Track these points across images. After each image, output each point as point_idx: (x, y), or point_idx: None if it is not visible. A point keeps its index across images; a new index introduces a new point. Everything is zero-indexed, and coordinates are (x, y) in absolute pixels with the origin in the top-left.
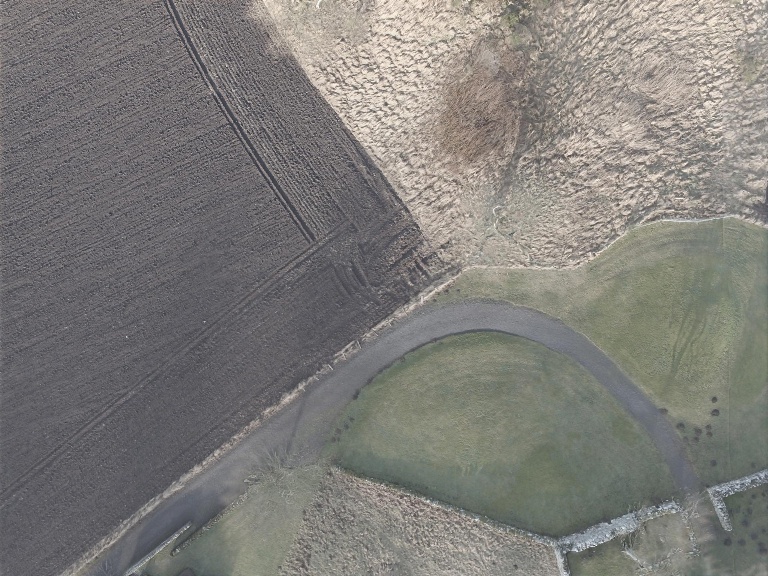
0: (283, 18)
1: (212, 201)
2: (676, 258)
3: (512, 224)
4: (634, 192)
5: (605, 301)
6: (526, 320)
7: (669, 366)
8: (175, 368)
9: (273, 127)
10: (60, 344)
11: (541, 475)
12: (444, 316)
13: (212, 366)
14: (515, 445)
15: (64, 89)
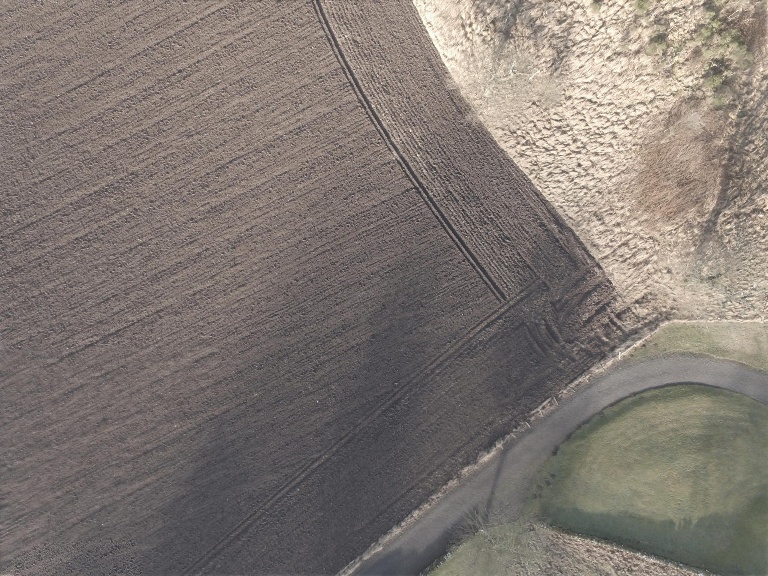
0: (469, 83)
1: (399, 264)
2: None
3: (713, 279)
4: None
5: None
6: (728, 372)
7: None
8: (368, 430)
9: (460, 190)
10: (250, 411)
11: (761, 527)
12: (642, 370)
13: (406, 427)
14: (730, 498)
15: (243, 159)
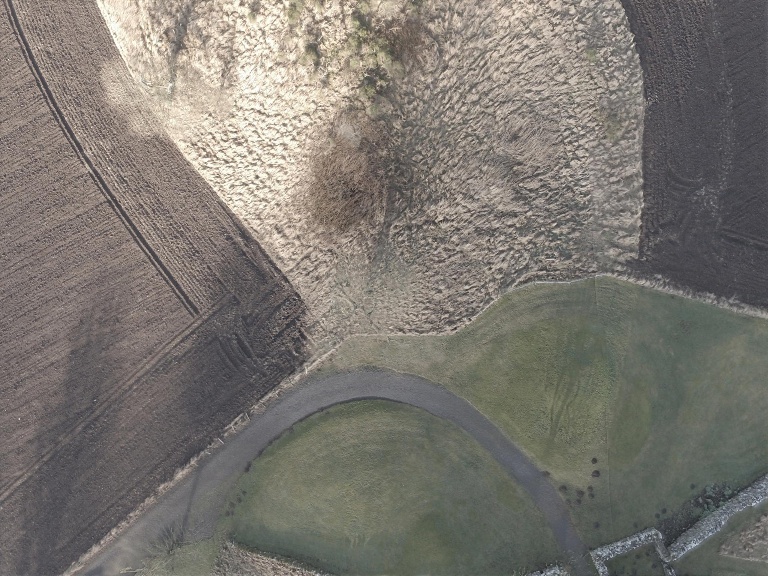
0: None
1: (95, 279)
2: (549, 320)
3: (388, 292)
4: (505, 255)
5: (483, 365)
6: (409, 386)
7: (548, 429)
8: (69, 448)
9: (150, 203)
10: None
11: (425, 545)
12: (329, 385)
13: (105, 444)
14: (400, 515)
15: None
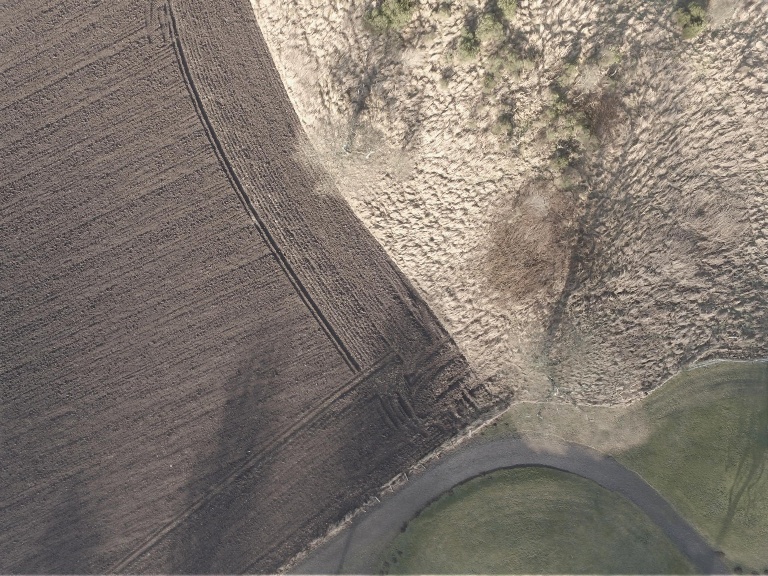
0: (326, 151)
1: (256, 331)
2: (731, 399)
3: None
4: (686, 331)
5: (658, 440)
6: (577, 456)
7: (725, 509)
8: (220, 497)
9: (317, 258)
10: (104, 473)
11: None
12: (493, 450)
13: (257, 496)
14: None
15: (105, 217)
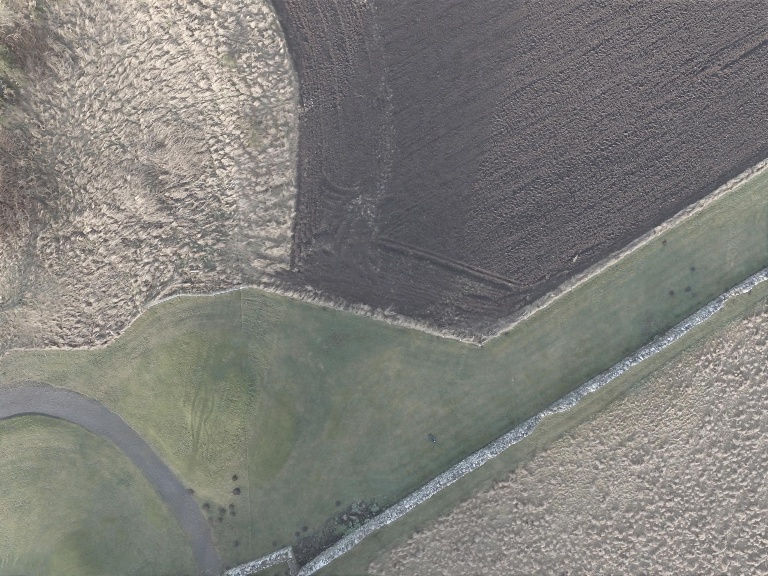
0: None
1: None
2: (191, 334)
3: (39, 305)
4: (149, 267)
5: (132, 380)
6: (66, 402)
7: (190, 445)
8: None
9: None
10: None
11: (65, 565)
12: None
13: None
14: (46, 534)
15: None
